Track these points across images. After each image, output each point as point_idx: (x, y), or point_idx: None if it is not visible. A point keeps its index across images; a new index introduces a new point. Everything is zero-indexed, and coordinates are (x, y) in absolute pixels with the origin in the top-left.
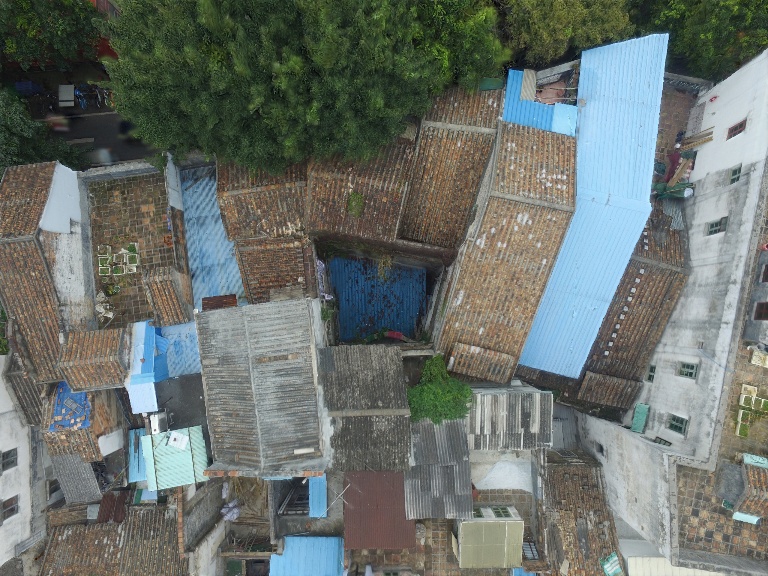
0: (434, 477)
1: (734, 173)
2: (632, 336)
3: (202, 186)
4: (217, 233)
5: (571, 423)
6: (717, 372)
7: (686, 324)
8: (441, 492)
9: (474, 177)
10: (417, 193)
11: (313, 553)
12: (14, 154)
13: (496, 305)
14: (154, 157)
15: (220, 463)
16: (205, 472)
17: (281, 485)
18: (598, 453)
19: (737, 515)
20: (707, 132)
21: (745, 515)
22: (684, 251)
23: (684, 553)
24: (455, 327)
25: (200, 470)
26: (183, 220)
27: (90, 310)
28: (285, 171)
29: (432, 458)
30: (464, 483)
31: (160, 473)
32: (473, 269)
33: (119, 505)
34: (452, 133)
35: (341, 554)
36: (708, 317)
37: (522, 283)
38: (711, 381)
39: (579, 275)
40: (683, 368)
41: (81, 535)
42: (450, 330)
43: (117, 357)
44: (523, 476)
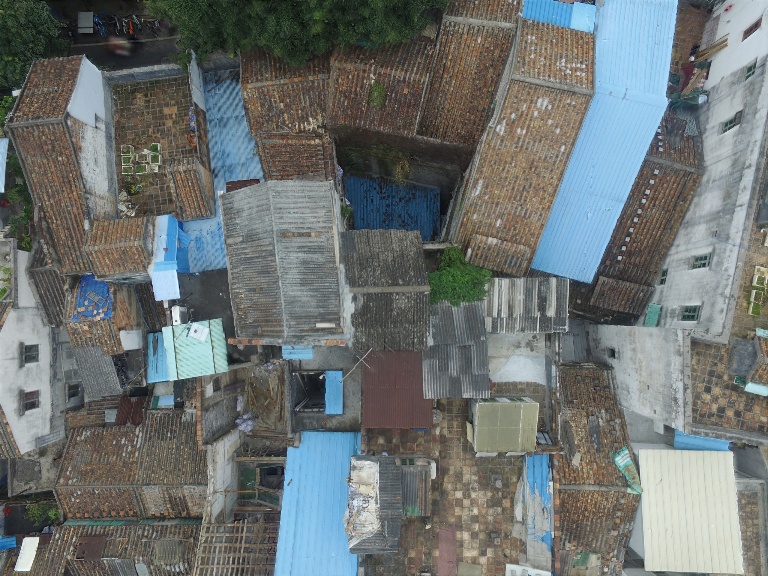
0: (452, 357)
1: (749, 70)
2: (645, 240)
3: (224, 88)
4: (239, 133)
5: (582, 338)
6: (731, 252)
7: (699, 220)
8: (458, 372)
9: (493, 75)
10: (436, 93)
11: (329, 446)
12: (40, 54)
13: (514, 195)
14: (178, 55)
15: (243, 338)
16: (230, 340)
17: (297, 388)
18: (609, 358)
19: (749, 387)
20: (722, 40)
21: (757, 387)
22: (698, 154)
23: (696, 426)
24: (473, 219)
25: (220, 361)
26: (205, 120)
27: (113, 207)
28: (308, 65)
29: (450, 338)
30: (481, 363)
31: (180, 363)
32: (492, 157)
33: (136, 409)
34: (473, 29)
35: (357, 447)
36: (722, 206)
37: (540, 172)
38: (725, 262)
39: (595, 174)
40: (696, 262)
41: (99, 436)
42: (468, 222)
43: (141, 242)
44: (537, 369)
